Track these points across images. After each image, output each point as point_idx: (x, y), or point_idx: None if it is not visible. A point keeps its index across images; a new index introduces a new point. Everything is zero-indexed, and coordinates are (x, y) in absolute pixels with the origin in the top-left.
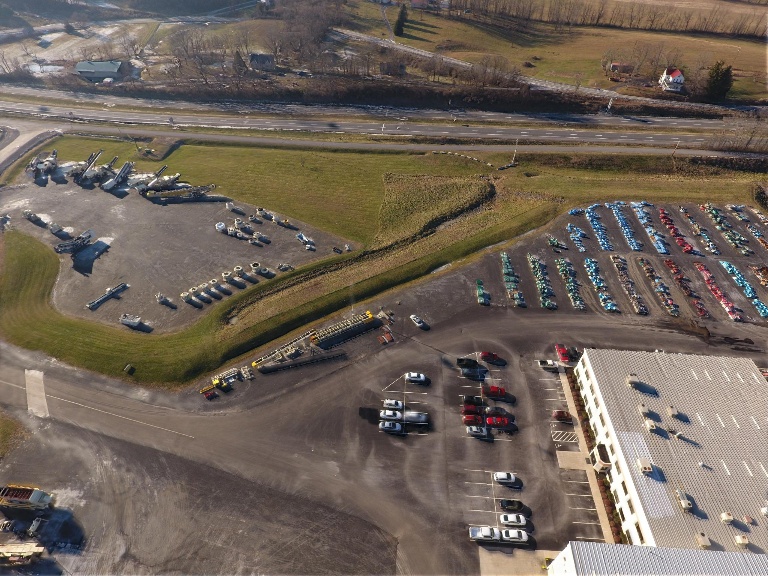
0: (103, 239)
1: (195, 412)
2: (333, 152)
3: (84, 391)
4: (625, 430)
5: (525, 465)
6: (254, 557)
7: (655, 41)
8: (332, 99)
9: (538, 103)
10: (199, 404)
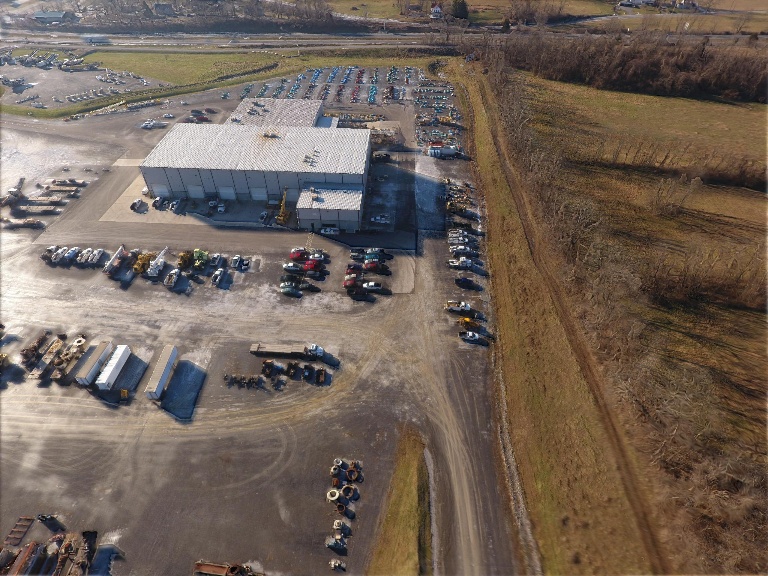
0: (32, 83)
1: (58, 124)
2: (190, 54)
3: (8, 119)
4: None
5: None
6: (68, 152)
7: None
8: (204, 29)
9: (339, 27)
10: (60, 122)
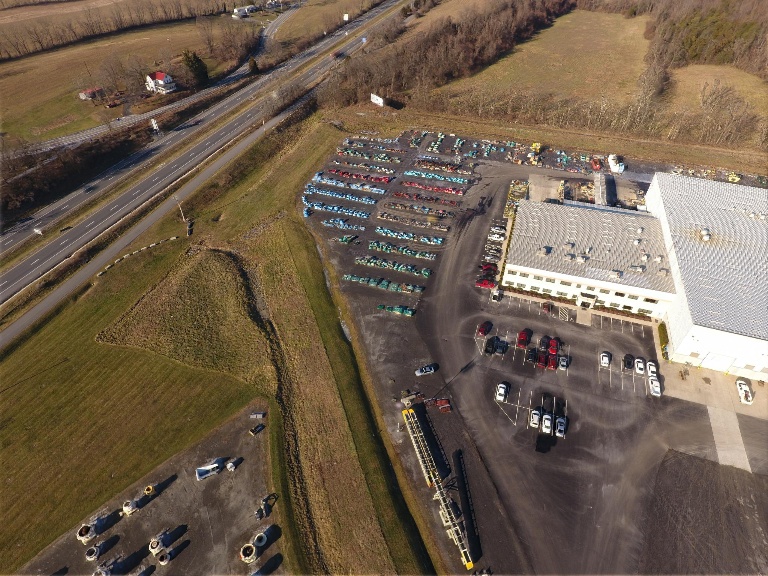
0: None
1: None
2: None
3: None
4: (584, 273)
5: (591, 344)
6: None
7: (82, 58)
8: None
9: (94, 161)
10: None
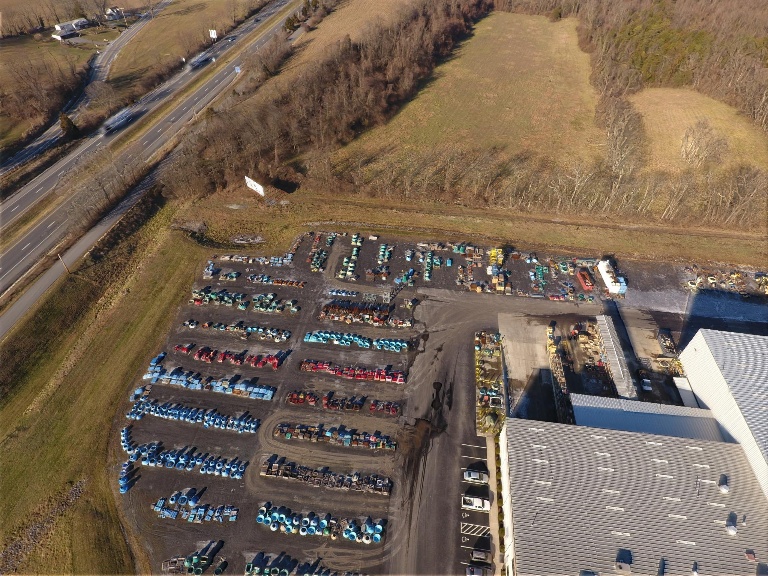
0: None
1: None
2: None
3: None
4: None
5: None
6: None
7: None
8: None
9: None
10: None
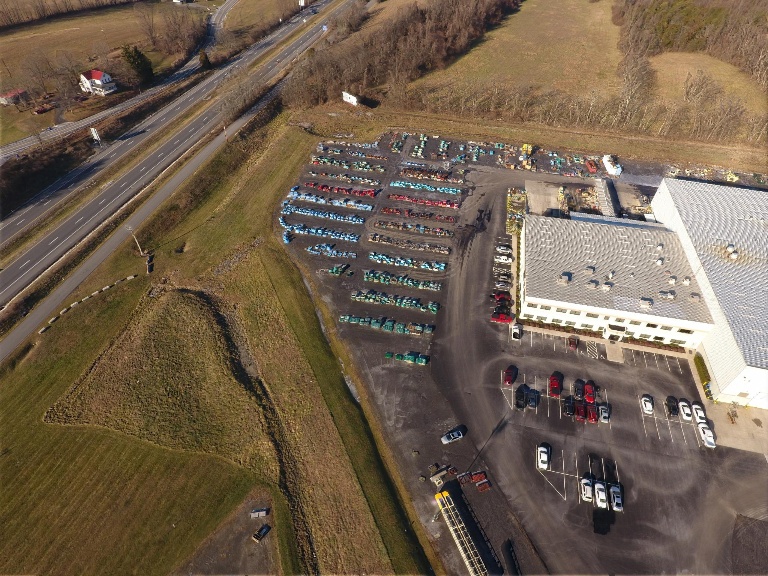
0: None
1: None
2: None
3: None
4: (613, 303)
5: (628, 387)
6: None
7: None
8: None
9: (24, 183)
10: None
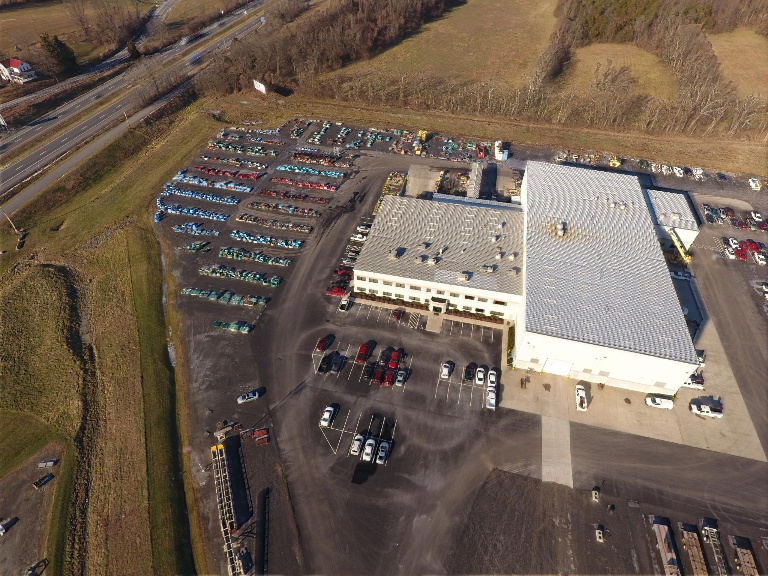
0: None
1: None
2: None
3: None
4: (433, 276)
5: (436, 354)
6: None
7: None
8: None
9: None
10: None
